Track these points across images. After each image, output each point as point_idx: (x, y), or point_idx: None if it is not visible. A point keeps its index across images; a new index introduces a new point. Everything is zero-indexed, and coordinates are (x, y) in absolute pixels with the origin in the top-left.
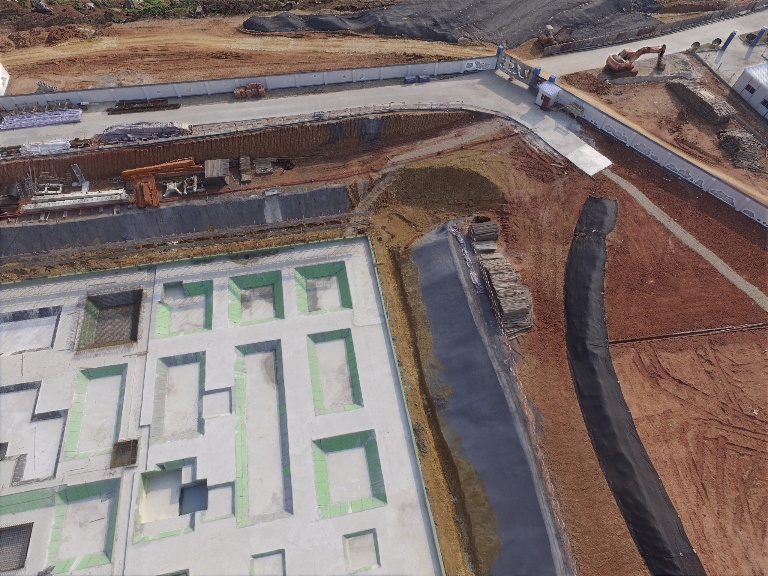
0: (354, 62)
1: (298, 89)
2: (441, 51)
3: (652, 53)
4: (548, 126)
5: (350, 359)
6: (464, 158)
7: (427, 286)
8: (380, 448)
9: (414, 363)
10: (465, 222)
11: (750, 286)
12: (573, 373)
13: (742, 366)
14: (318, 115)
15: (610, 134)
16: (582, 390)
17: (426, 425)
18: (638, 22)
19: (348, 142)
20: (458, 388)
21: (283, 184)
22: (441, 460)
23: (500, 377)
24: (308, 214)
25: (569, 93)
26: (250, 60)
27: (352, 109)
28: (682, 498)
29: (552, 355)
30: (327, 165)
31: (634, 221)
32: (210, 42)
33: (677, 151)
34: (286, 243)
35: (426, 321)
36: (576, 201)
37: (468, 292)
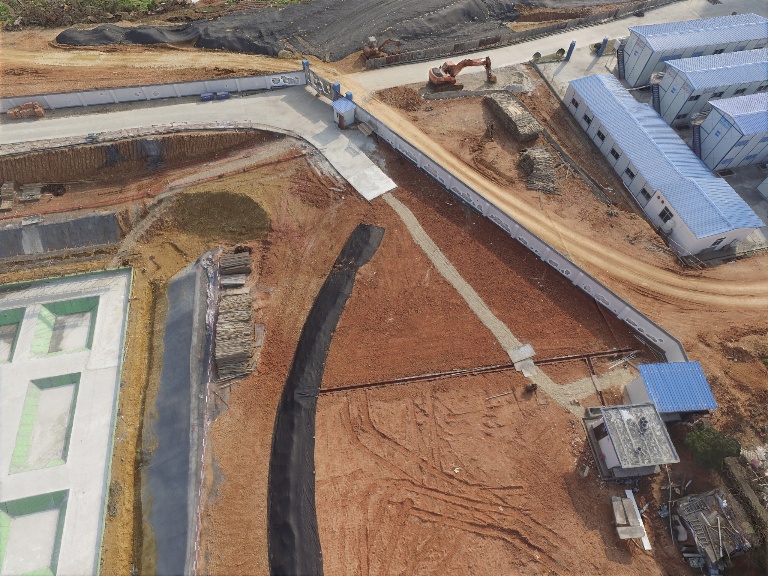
0: (158, 78)
1: (84, 108)
2: (258, 65)
3: (476, 66)
4: (339, 146)
5: (73, 407)
6: (243, 182)
7: (170, 324)
8: (68, 511)
9: (140, 411)
10: (223, 253)
11: (498, 323)
12: (276, 426)
13: (459, 416)
14: (90, 137)
15: (404, 154)
16: (276, 446)
17: (126, 484)
18: (488, 31)
19: (129, 165)
20: (163, 442)
21: (46, 212)
22: (135, 523)
23: (192, 432)
24: (73, 244)
25: (364, 111)
26: (48, 76)
27: (133, 130)
28: (338, 575)
29: (262, 405)
30: (102, 190)
31: (396, 251)
32: (14, 57)
33: (471, 172)
34: (39, 277)
35: (160, 364)
36: (345, 229)
37: (195, 333)
